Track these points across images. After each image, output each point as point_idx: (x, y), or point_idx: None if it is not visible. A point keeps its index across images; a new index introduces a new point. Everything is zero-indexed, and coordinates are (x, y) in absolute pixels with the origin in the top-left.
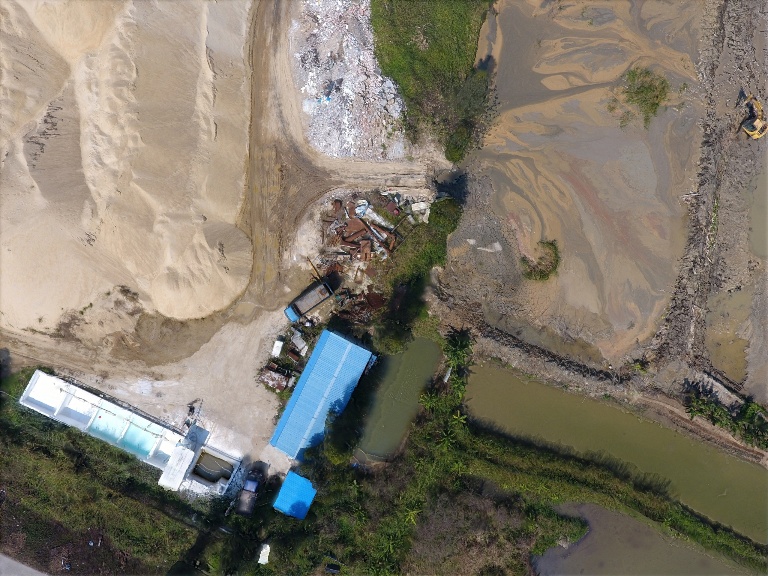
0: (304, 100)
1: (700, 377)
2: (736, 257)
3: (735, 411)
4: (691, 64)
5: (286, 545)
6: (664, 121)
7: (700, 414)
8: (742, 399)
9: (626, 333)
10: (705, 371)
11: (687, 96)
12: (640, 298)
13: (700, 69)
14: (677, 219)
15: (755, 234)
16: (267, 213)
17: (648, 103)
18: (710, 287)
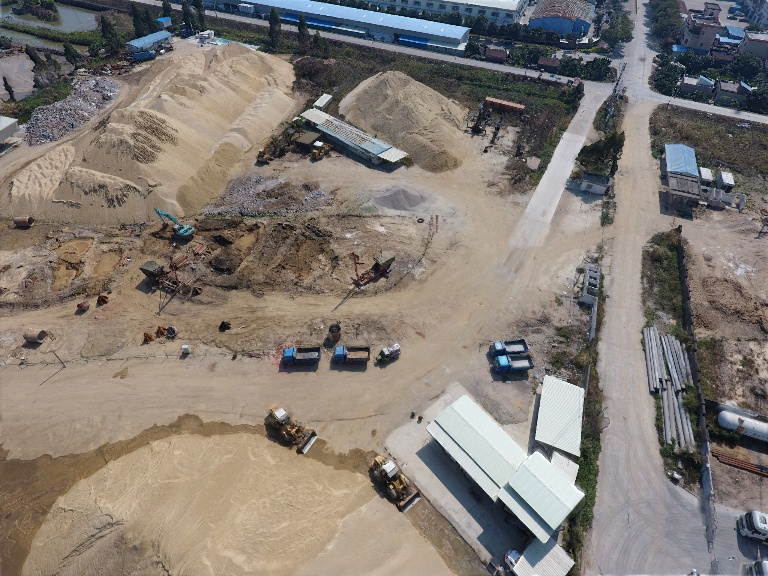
0: (117, 92)
1: None
2: None
3: None
4: None
5: (164, 6)
6: None
7: None
8: None
9: None
10: None
11: None
12: None
13: None
14: None
15: None
16: (151, 73)
17: None
18: None
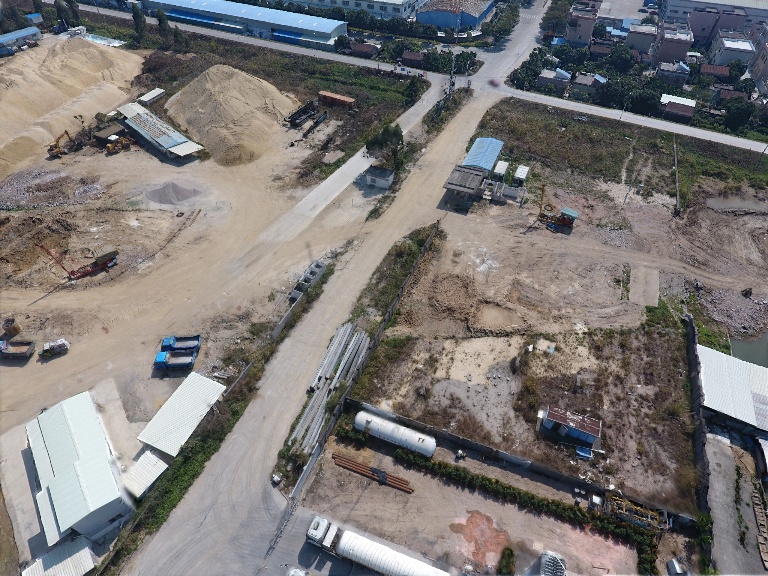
0: None
1: None
2: None
3: None
4: None
5: (34, 2)
6: None
7: None
8: None
9: None
10: None
11: None
12: None
13: None
14: None
15: None
16: None
17: None
18: None
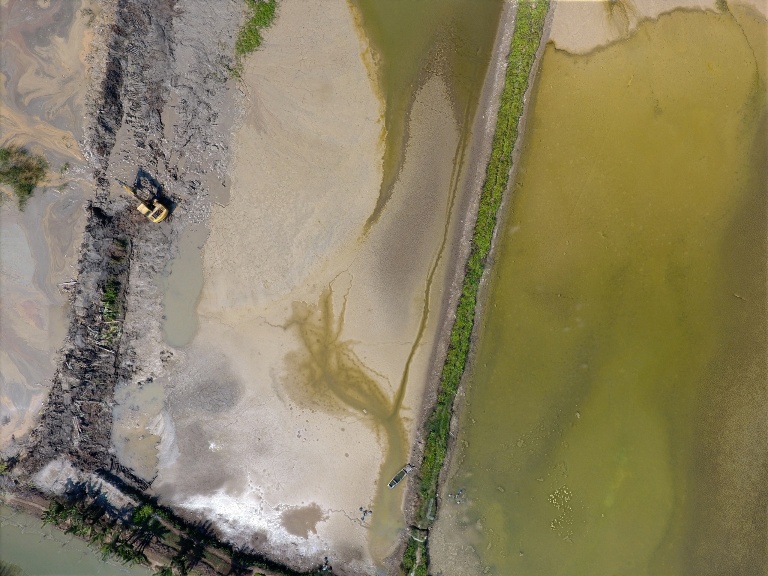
0: None
1: (87, 477)
2: (147, 347)
3: (127, 514)
4: (75, 142)
5: None
6: (43, 203)
7: (49, 522)
8: (137, 501)
9: (1, 429)
10: (100, 469)
11: (72, 176)
12: (14, 392)
13: (85, 148)
14: (57, 308)
15: (170, 322)
16: None
17: (17, 185)
18: (114, 379)
